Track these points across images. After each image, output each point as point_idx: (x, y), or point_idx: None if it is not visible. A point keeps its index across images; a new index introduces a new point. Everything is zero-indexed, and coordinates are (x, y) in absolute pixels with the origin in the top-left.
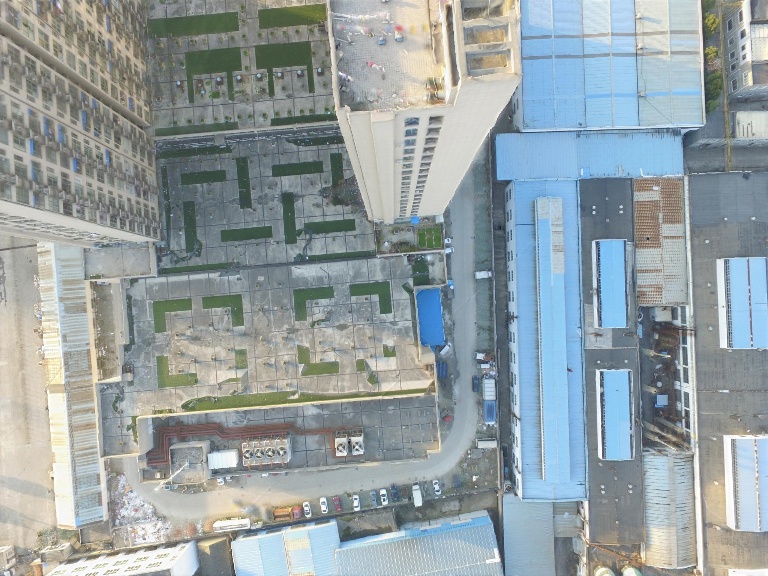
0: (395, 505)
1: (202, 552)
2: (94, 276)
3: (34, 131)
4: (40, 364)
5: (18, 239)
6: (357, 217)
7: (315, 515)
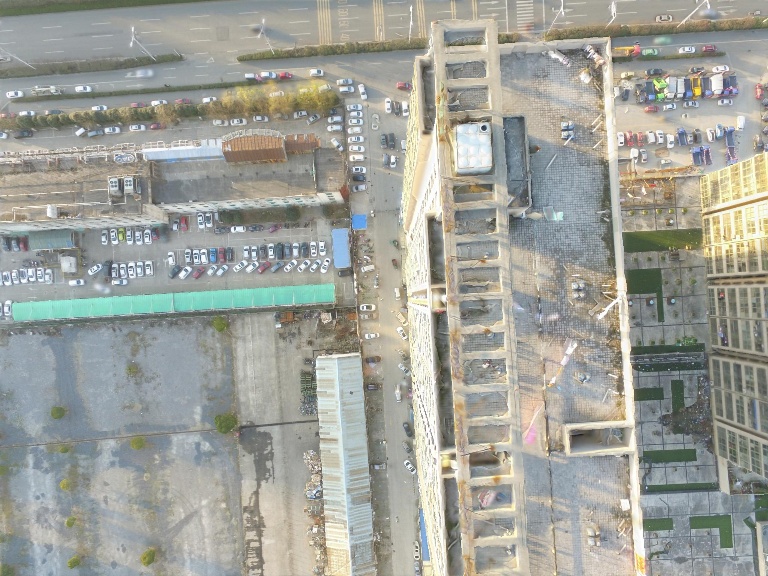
0: None
1: None
2: None
3: None
4: (310, 545)
5: (287, 414)
6: (698, 447)
7: None
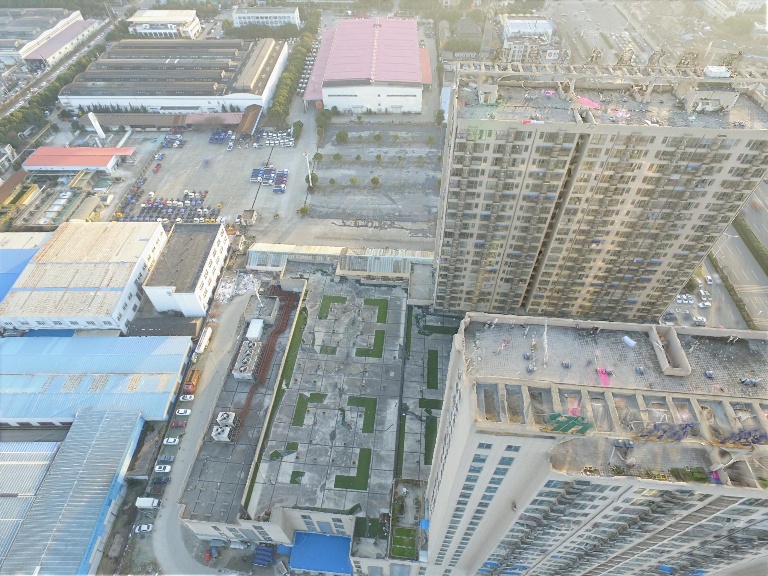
0: (150, 479)
1: (195, 319)
2: (413, 268)
3: (497, 218)
4: None
5: None
6: None
7: (179, 404)
